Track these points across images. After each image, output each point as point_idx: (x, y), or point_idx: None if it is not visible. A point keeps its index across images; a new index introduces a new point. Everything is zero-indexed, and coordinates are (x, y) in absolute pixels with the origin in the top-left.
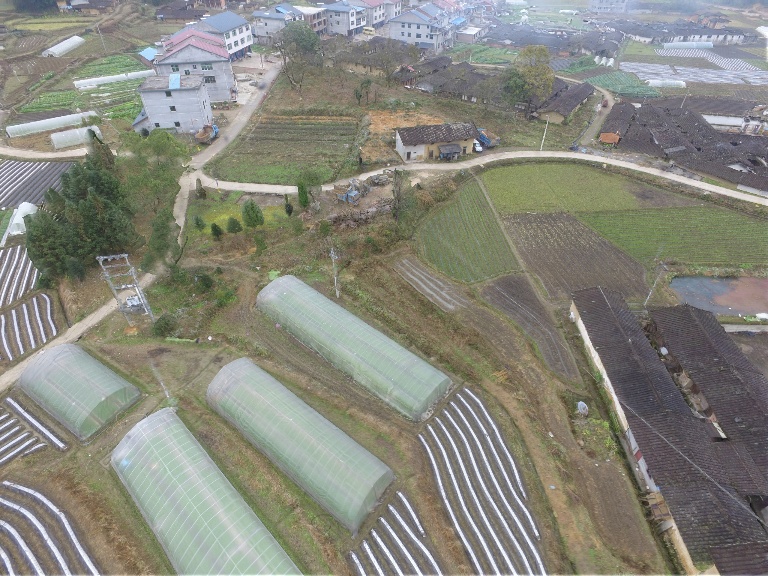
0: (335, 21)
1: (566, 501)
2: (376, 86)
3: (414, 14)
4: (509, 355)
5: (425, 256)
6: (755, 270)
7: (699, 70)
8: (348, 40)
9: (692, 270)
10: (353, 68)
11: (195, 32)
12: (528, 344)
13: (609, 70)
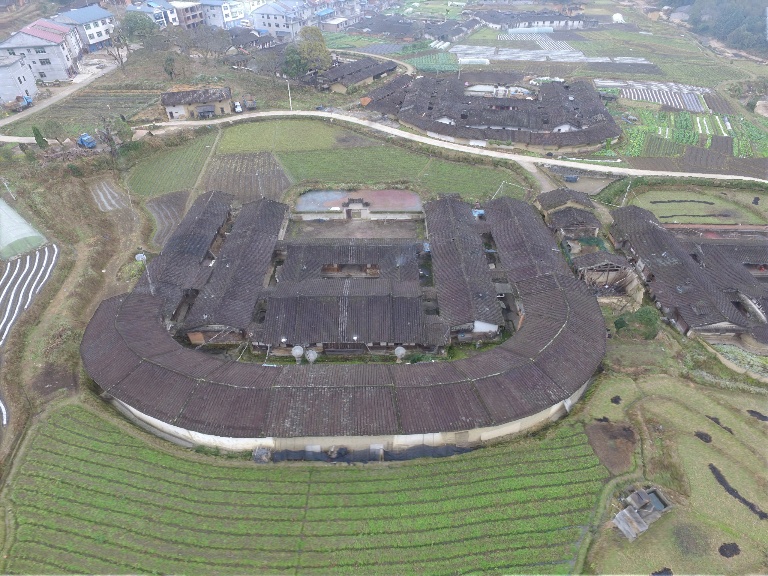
0: (212, 14)
1: (66, 296)
2: (199, 66)
3: (270, 6)
4: (123, 233)
5: (128, 181)
6: (372, 184)
7: (519, 50)
8: None
9: (324, 185)
10: (198, 53)
11: (41, 22)
12: (145, 228)
13: (437, 52)
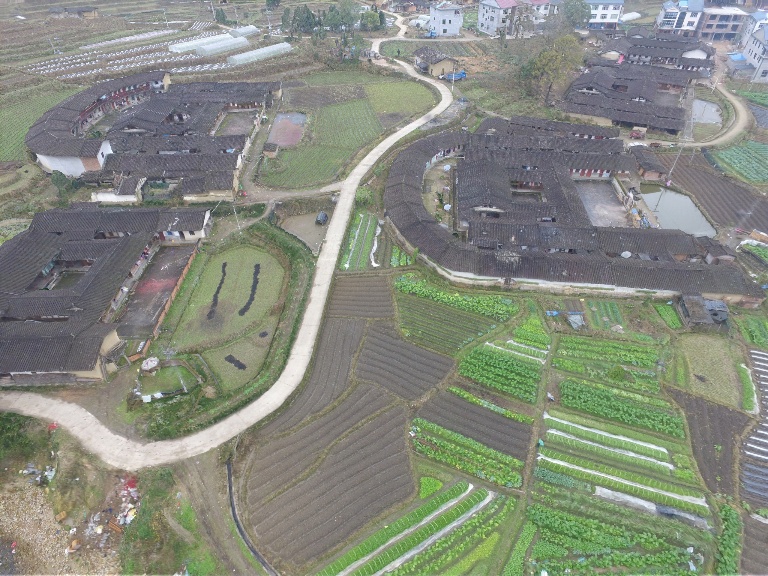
0: (749, 29)
1: None
2: None
3: (764, 30)
4: None
5: None
6: None
7: None
8: (687, 40)
9: None
10: None
11: None
12: None
13: None
